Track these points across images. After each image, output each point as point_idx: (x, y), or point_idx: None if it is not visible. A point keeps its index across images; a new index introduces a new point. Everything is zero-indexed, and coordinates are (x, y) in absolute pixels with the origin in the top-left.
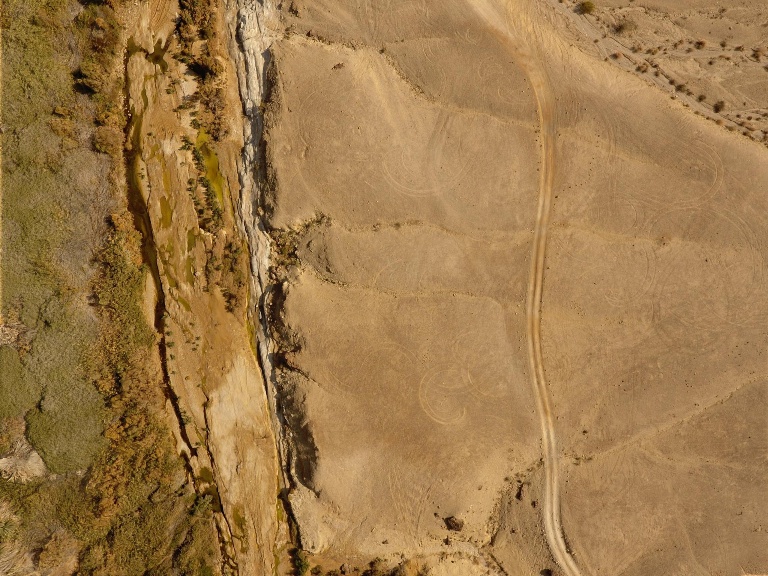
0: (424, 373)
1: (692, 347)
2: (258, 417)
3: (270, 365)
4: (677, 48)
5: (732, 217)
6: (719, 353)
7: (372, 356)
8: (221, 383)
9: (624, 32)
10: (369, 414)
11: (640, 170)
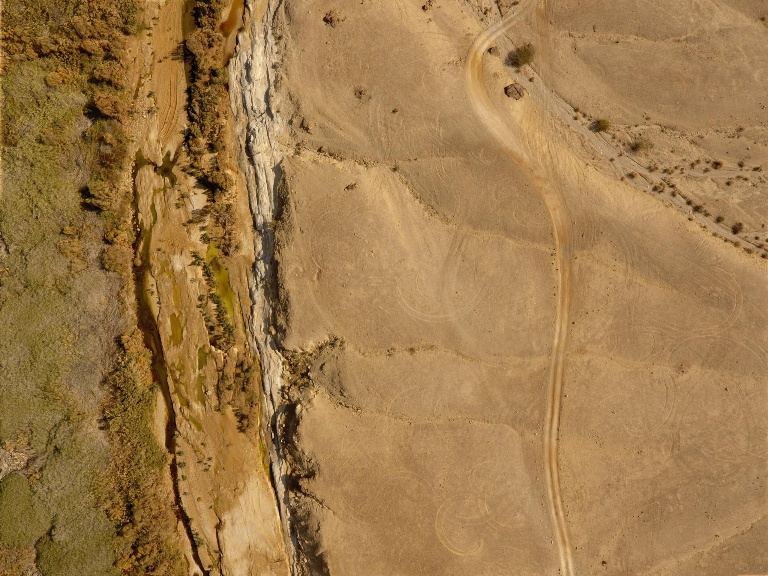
0: (440, 503)
1: (712, 478)
2: (271, 540)
3: (283, 487)
4: (694, 168)
5: (752, 346)
6: (740, 485)
7: (387, 485)
8: (234, 505)
9: (640, 151)
10: (385, 544)
11: (658, 296)
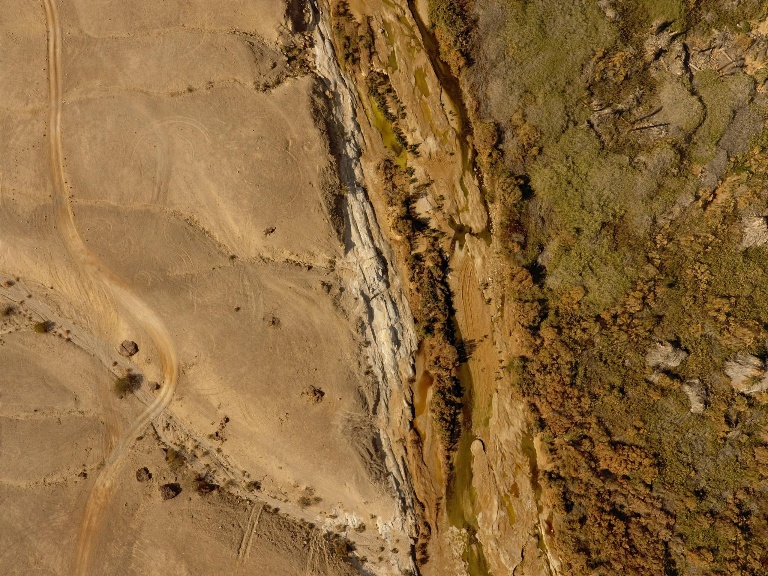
0: None
1: None
2: None
3: None
4: None
5: None
6: None
7: None
8: None
9: (4, 309)
10: None
11: None
